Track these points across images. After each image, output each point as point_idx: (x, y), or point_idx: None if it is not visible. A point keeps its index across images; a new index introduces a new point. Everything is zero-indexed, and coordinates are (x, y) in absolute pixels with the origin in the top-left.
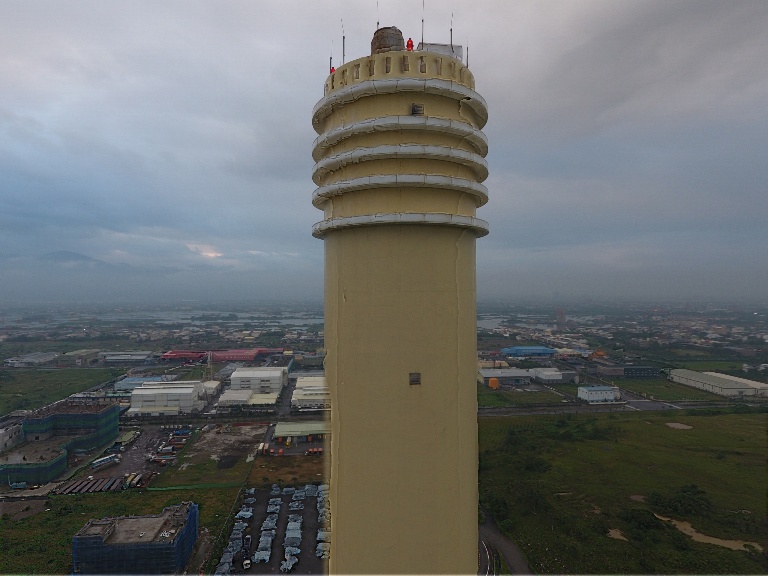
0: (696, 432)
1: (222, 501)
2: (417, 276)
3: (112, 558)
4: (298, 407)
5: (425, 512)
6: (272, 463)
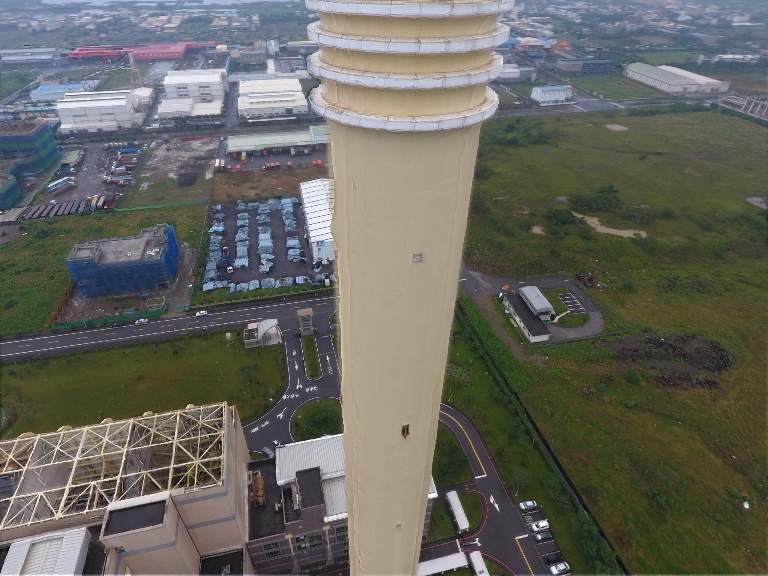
0: (630, 134)
1: (193, 218)
2: (425, 175)
3: (109, 274)
4: (246, 117)
5: (418, 338)
6: (232, 179)
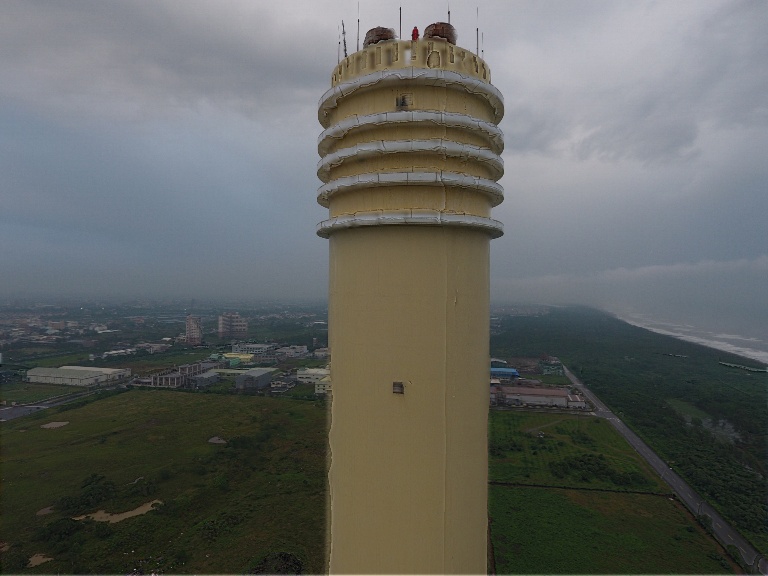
0: (74, 426)
1: None
2: None
3: None
4: None
5: None
6: None
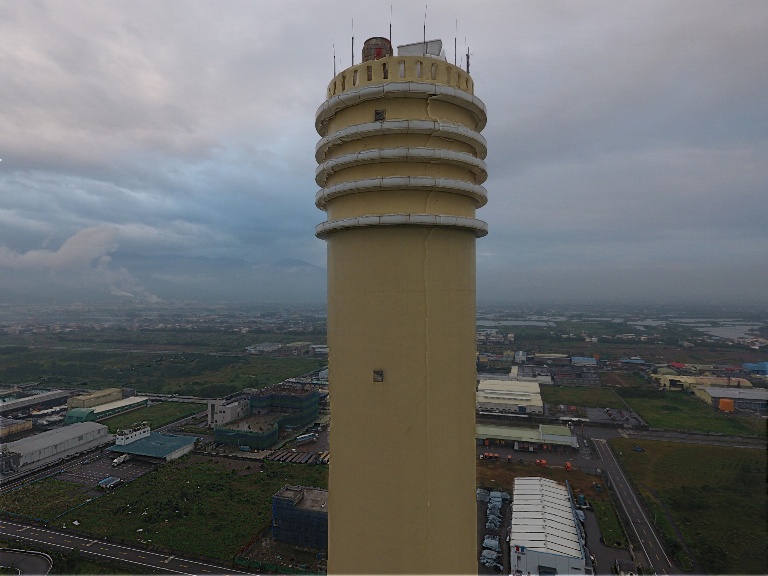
0: None
1: None
2: (381, 277)
3: (300, 520)
4: (478, 409)
5: (389, 507)
6: None
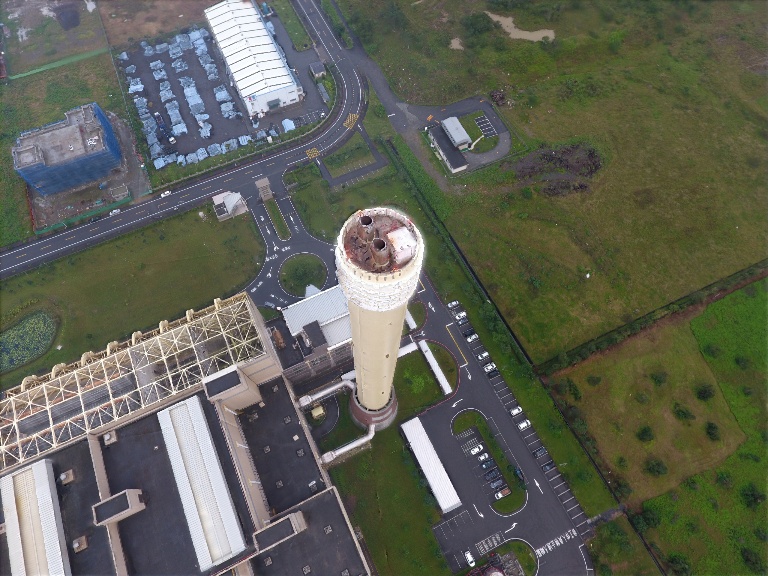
0: None
1: (103, 76)
2: None
3: (61, 172)
4: None
5: (391, 336)
6: (120, 8)
